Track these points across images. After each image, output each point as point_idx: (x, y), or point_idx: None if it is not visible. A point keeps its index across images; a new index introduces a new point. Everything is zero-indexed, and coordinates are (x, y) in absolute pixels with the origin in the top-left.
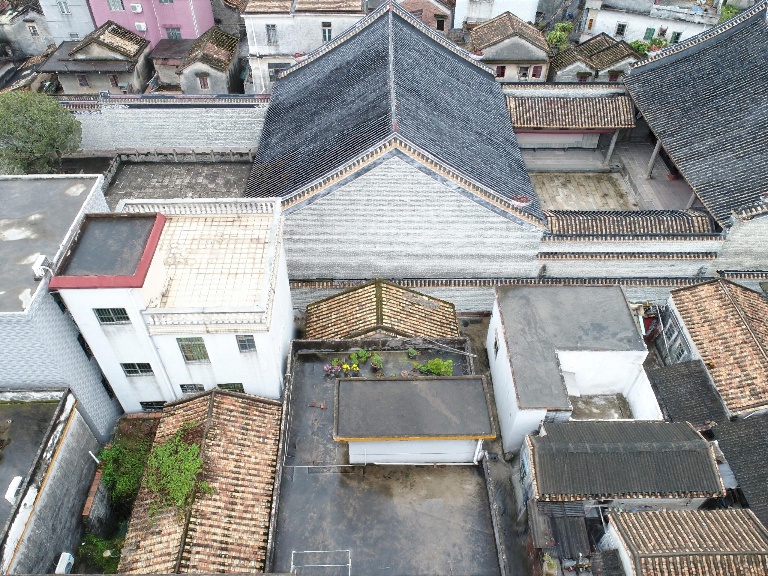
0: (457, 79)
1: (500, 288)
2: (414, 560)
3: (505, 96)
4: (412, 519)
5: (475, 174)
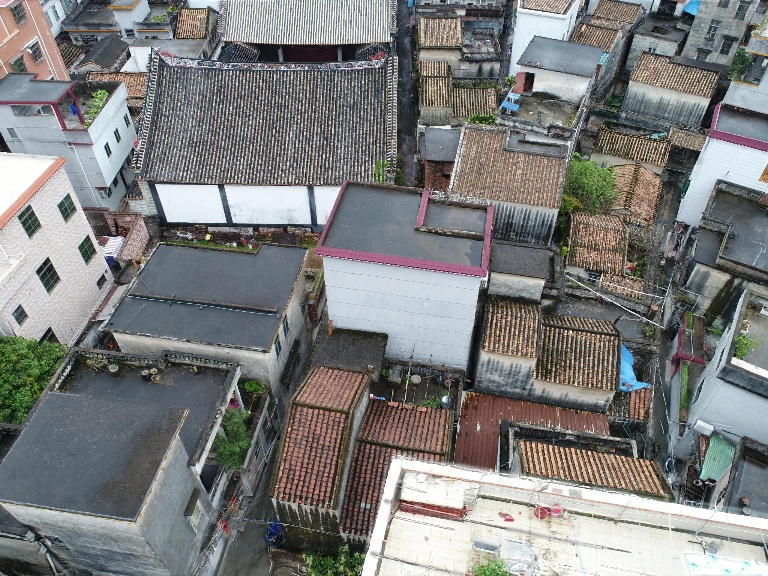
0: (359, 6)
1: (204, 41)
2: (95, 19)
3: (379, 44)
4: (107, 19)
5: (247, 2)
